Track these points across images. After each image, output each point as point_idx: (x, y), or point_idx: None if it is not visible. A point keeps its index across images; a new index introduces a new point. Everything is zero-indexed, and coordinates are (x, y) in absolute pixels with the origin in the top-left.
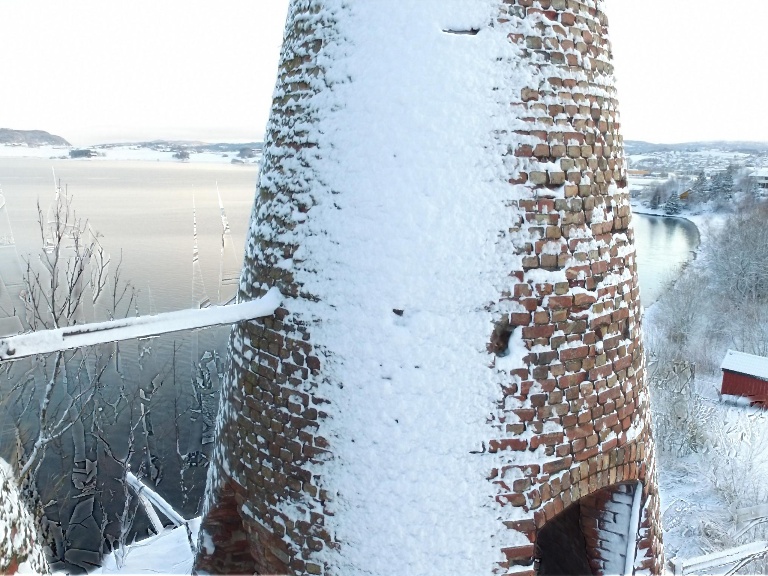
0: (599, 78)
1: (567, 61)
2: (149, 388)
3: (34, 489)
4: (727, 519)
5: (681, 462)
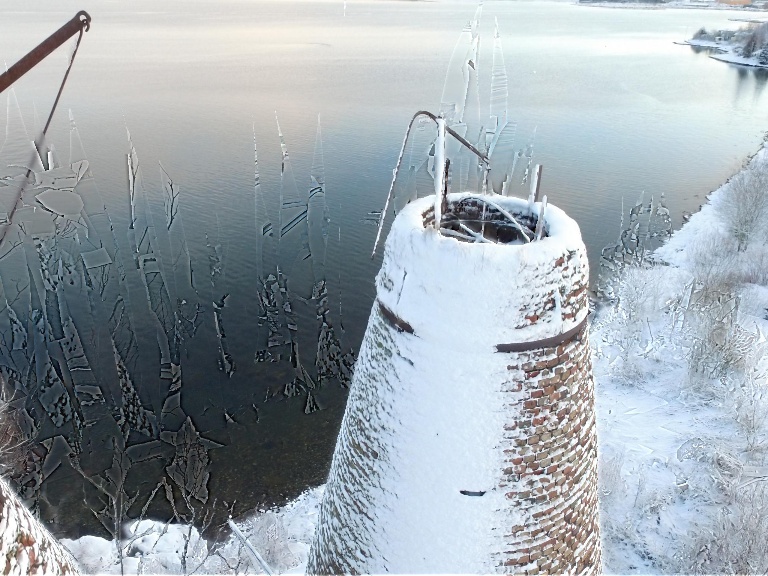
0: (575, 489)
1: (549, 497)
2: (221, 302)
3: (131, 386)
4: (742, 449)
5: (711, 386)
